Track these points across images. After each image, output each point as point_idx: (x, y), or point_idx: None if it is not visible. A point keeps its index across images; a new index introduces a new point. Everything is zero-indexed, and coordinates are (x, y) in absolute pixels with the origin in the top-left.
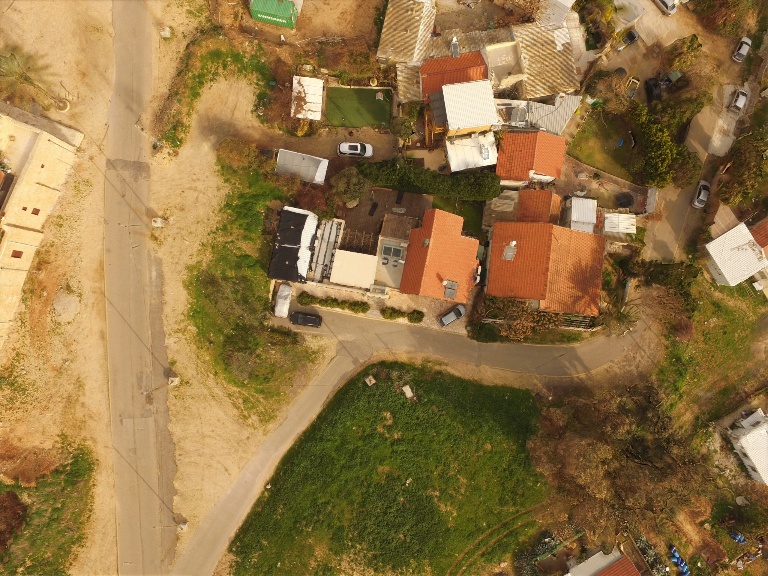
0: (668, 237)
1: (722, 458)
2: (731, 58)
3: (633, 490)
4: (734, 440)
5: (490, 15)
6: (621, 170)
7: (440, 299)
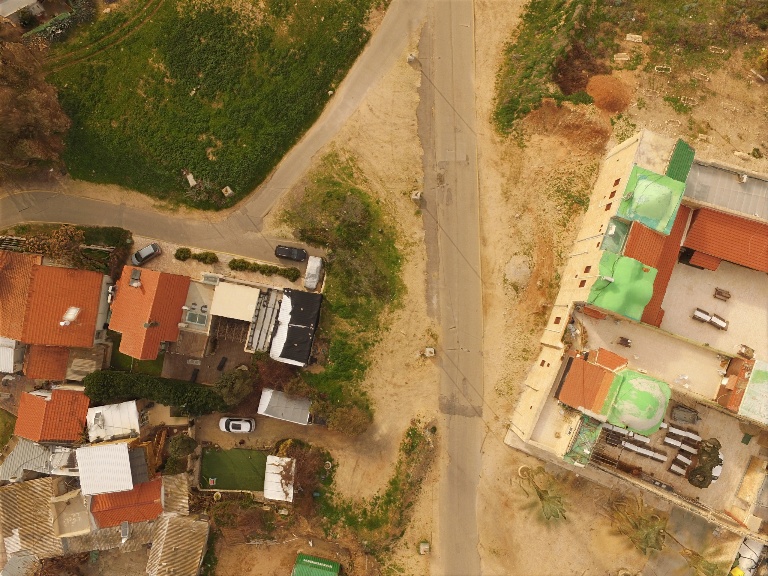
0: None
1: None
2: None
3: None
4: None
5: (96, 569)
6: None
7: None
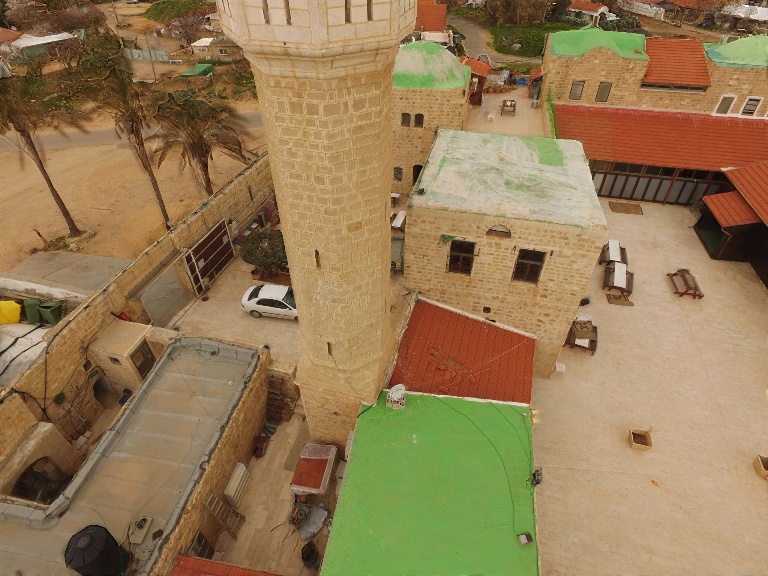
0: None
1: None
2: None
3: None
4: None
5: None
6: None
7: None
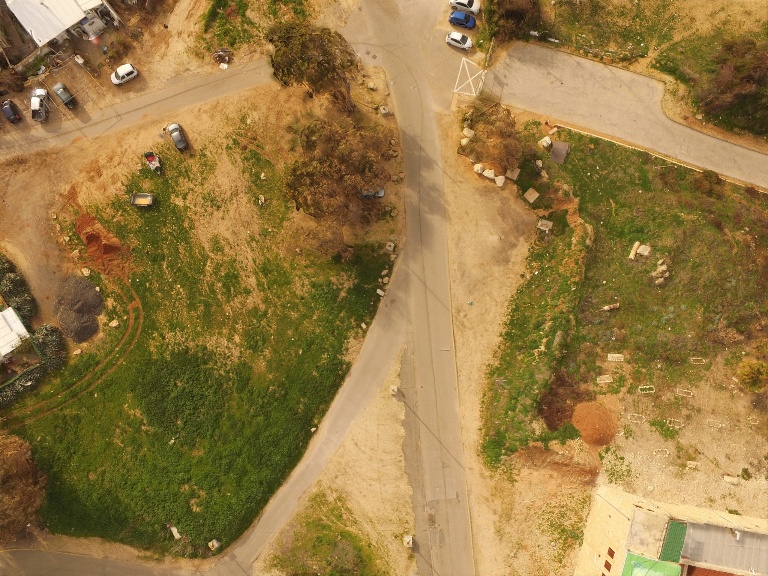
0: None
1: None
2: None
3: None
4: None
5: None
6: None
7: None
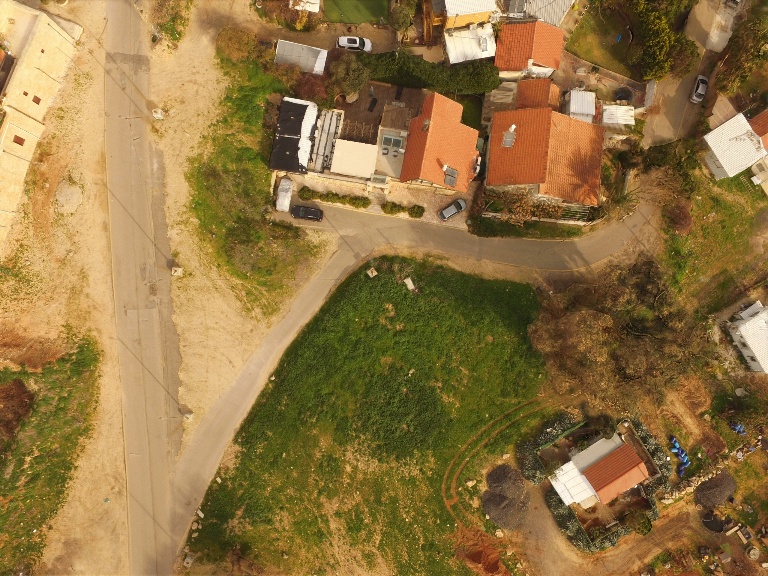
0: (666, 132)
1: (721, 350)
2: None
3: (633, 356)
4: (733, 330)
5: None
6: (619, 66)
7: (440, 194)
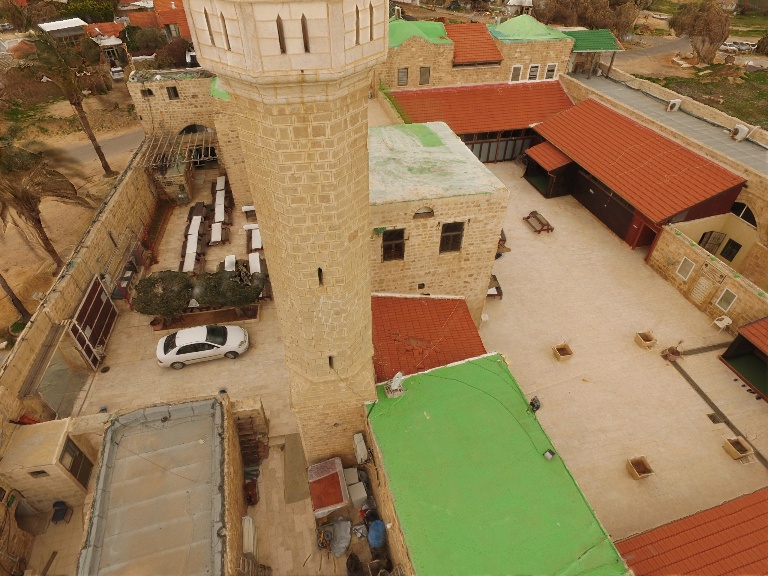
0: None
1: None
2: (11, 29)
3: None
4: None
5: None
6: None
7: None
